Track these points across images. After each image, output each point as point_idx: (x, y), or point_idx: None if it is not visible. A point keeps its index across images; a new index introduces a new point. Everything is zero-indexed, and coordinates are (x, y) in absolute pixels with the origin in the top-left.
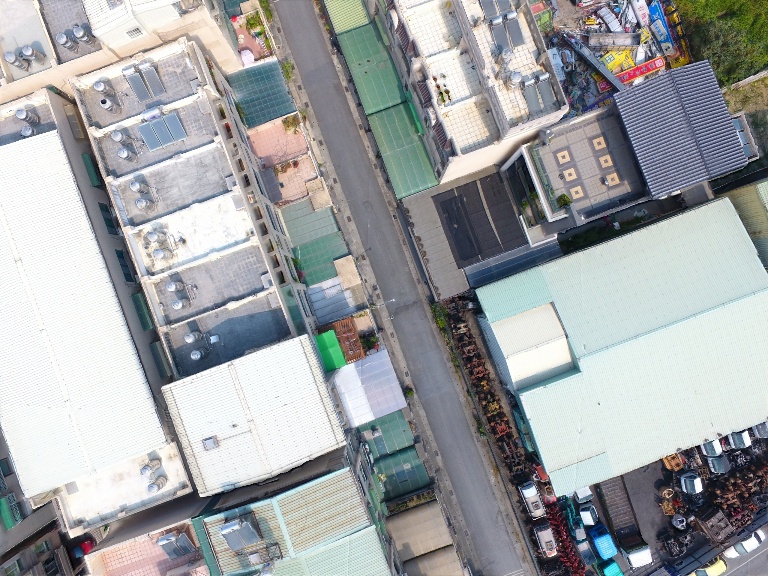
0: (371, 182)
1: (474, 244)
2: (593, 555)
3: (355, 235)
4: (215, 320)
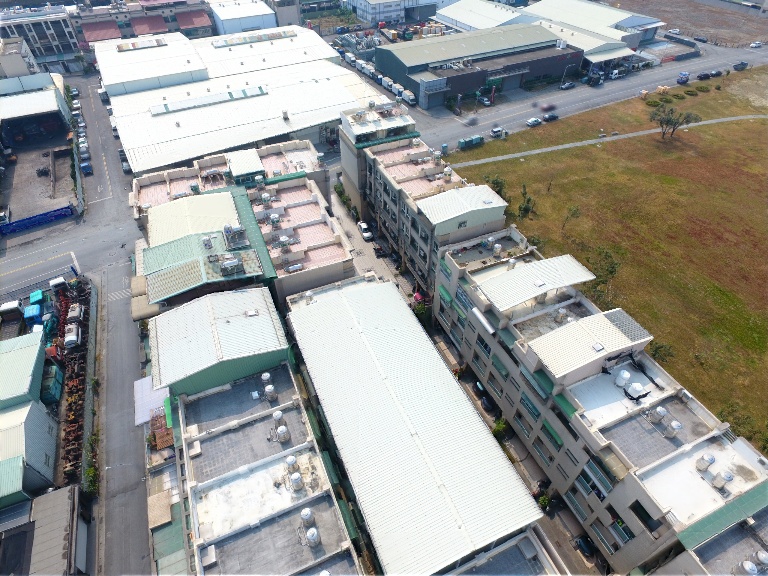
0: None
1: (2, 552)
2: (45, 307)
3: (156, 575)
4: (254, 412)
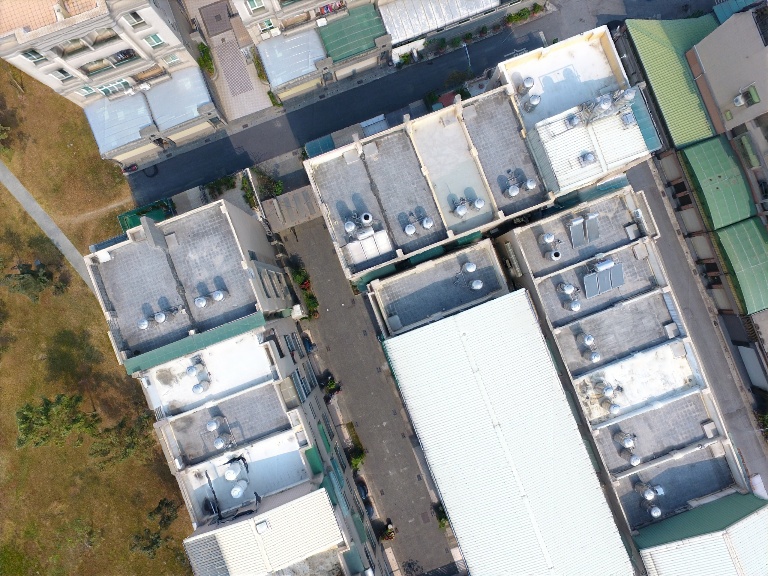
0: (691, 288)
1: None
2: None
3: None
4: (655, 470)
